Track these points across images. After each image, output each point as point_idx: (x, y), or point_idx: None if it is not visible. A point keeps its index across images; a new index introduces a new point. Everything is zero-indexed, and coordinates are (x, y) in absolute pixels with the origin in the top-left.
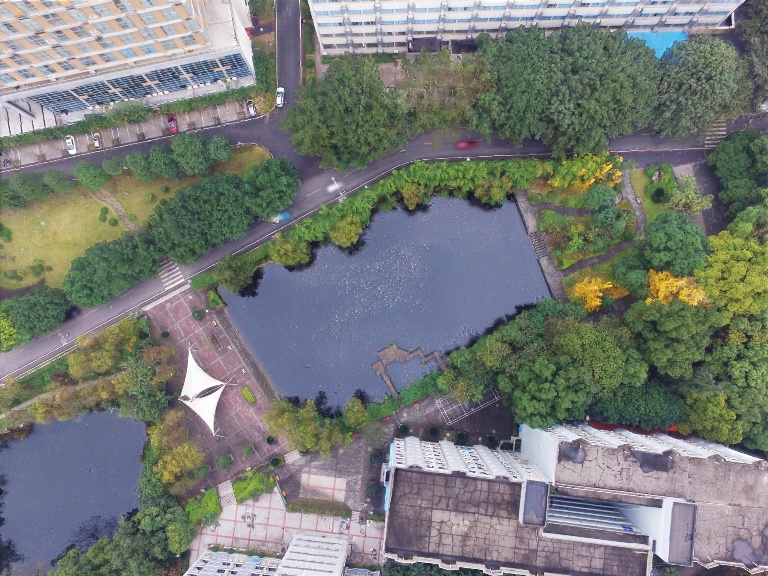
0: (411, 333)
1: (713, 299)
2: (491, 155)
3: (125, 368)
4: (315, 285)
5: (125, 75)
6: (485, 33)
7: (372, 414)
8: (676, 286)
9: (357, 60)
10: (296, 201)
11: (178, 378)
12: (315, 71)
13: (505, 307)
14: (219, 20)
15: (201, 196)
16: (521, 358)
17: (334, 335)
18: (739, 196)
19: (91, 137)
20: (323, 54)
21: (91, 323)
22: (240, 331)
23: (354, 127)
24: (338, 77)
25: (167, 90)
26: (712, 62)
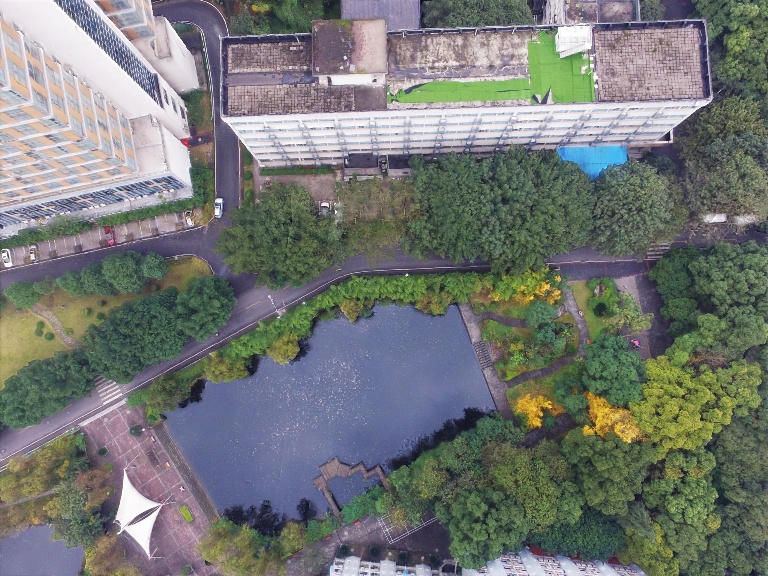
0: (353, 447)
1: (648, 433)
2: (432, 267)
3: (57, 493)
4: (256, 398)
5: (54, 199)
6: (419, 155)
7: (313, 533)
8: (611, 419)
9: (286, 189)
10: (235, 313)
11: (115, 496)
12: (253, 183)
13: (453, 410)
14: (149, 144)
15: (132, 320)
16: (458, 486)
17: (275, 449)
18: (678, 317)
19: (28, 249)
20: (261, 166)
21: (27, 439)
22: (179, 446)
23: (283, 258)
24: (265, 209)
25: (103, 203)
26: (642, 196)
